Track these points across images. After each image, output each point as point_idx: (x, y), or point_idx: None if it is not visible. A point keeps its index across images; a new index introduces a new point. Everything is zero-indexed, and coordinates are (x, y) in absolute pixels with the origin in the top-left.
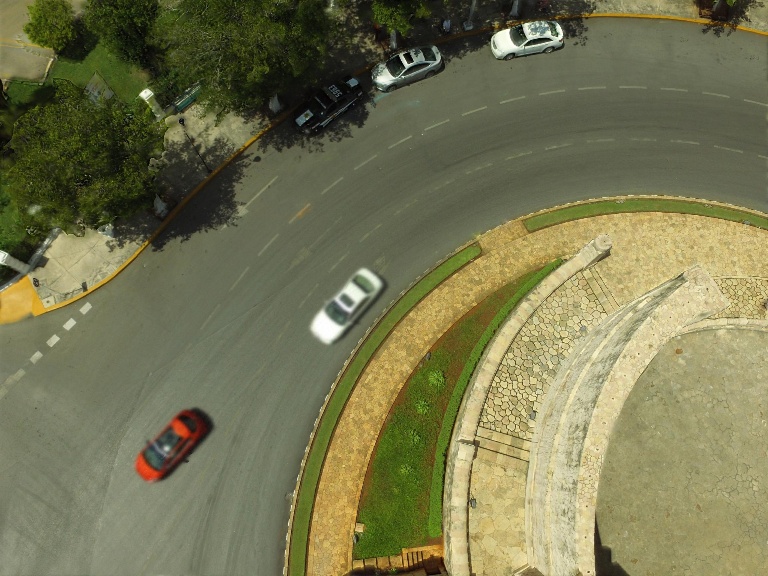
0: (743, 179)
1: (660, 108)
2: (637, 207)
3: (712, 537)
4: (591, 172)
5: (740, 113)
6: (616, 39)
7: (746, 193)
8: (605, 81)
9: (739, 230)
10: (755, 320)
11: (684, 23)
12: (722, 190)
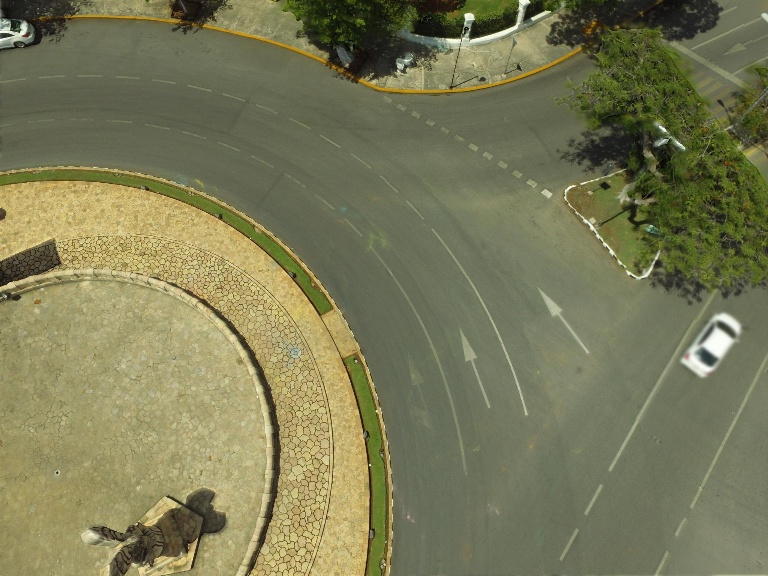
0: (160, 152)
1: (108, 93)
2: (49, 177)
3: (3, 470)
4: (21, 148)
5: (180, 97)
6: (90, 36)
7: (158, 163)
8: (66, 71)
9: (134, 194)
10: (101, 270)
11: (158, 23)
12: (138, 161)
